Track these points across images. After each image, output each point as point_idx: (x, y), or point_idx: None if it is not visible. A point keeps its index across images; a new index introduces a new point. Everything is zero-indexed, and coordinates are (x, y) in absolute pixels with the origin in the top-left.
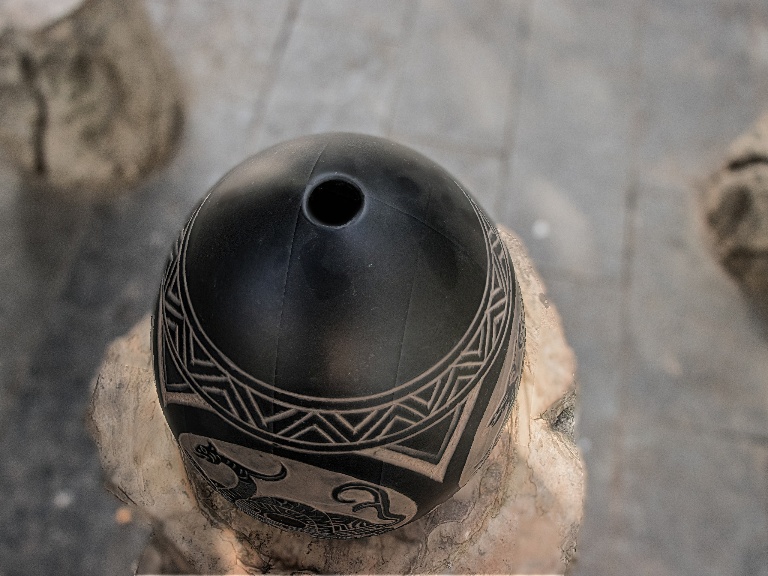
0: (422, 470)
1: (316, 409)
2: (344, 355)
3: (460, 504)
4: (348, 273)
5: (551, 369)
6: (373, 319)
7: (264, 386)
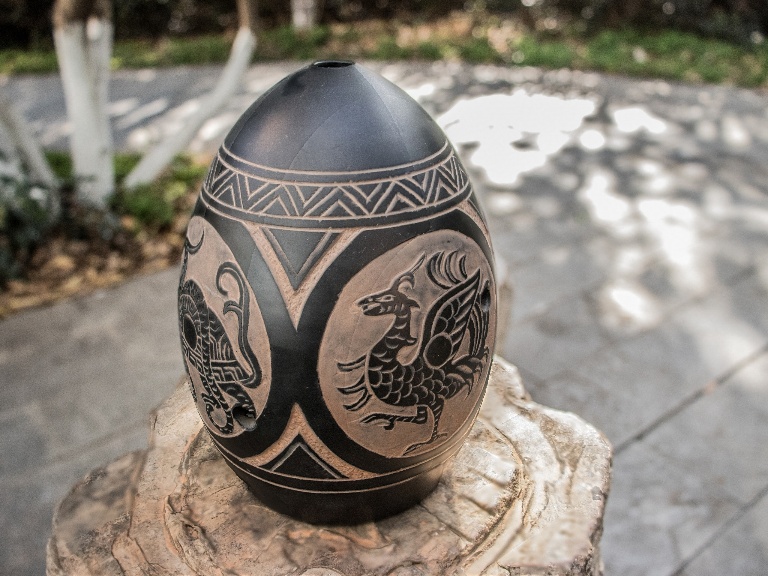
0: (282, 288)
1: (239, 171)
2: (272, 130)
3: (360, 566)
4: (307, 85)
5: (554, 540)
6: (301, 114)
7: None
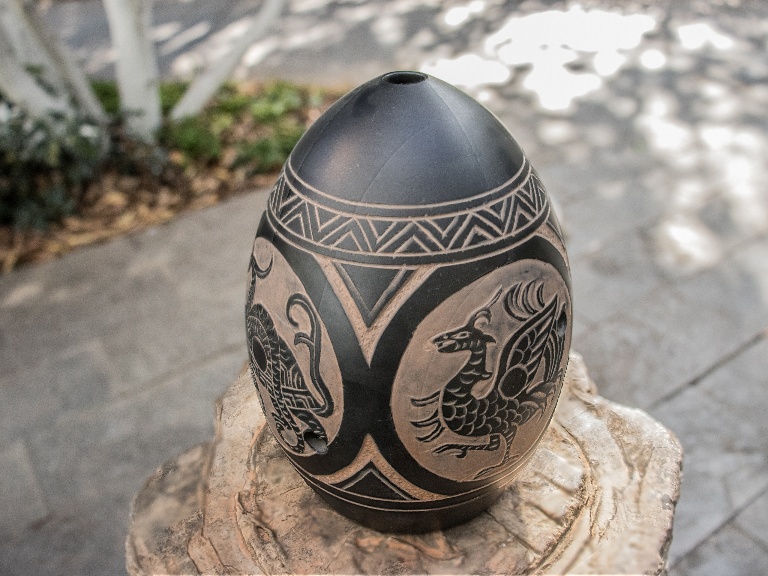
0: (355, 324)
1: (308, 198)
2: (342, 157)
3: None
4: (378, 106)
5: (623, 554)
6: (373, 140)
7: (293, 175)
